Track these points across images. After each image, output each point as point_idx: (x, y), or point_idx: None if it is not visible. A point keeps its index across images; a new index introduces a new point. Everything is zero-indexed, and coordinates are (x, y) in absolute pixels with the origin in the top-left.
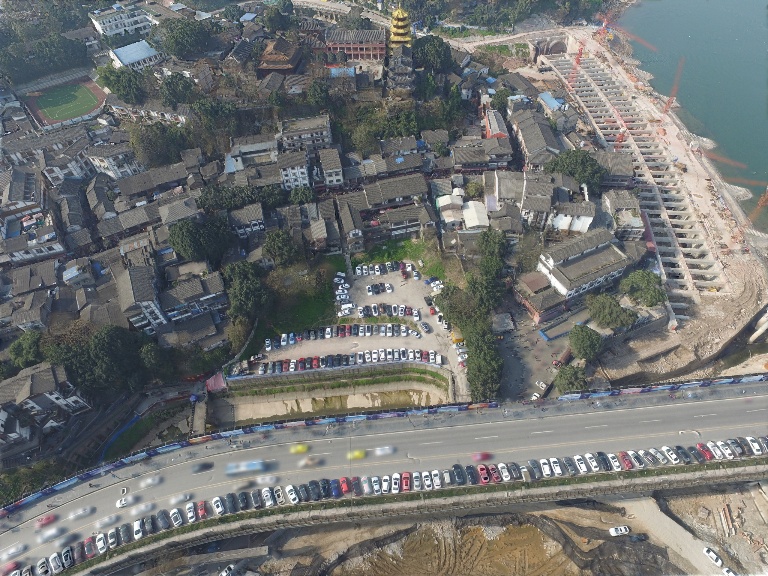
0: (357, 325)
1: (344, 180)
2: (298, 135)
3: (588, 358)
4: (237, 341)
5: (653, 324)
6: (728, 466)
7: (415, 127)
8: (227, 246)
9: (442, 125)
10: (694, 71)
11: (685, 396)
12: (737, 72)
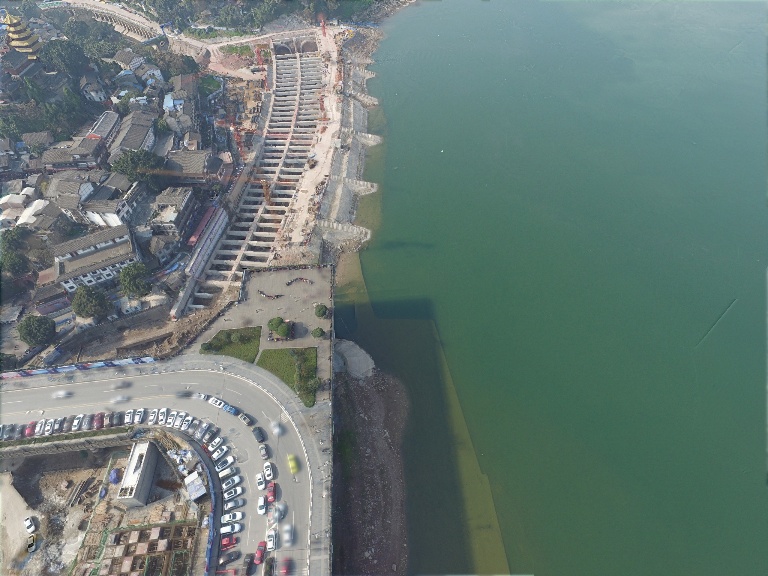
0: None
1: None
2: None
3: (63, 346)
4: None
5: (149, 313)
6: (39, 441)
7: (16, 129)
8: None
9: None
10: (417, 69)
11: (61, 379)
12: (456, 70)
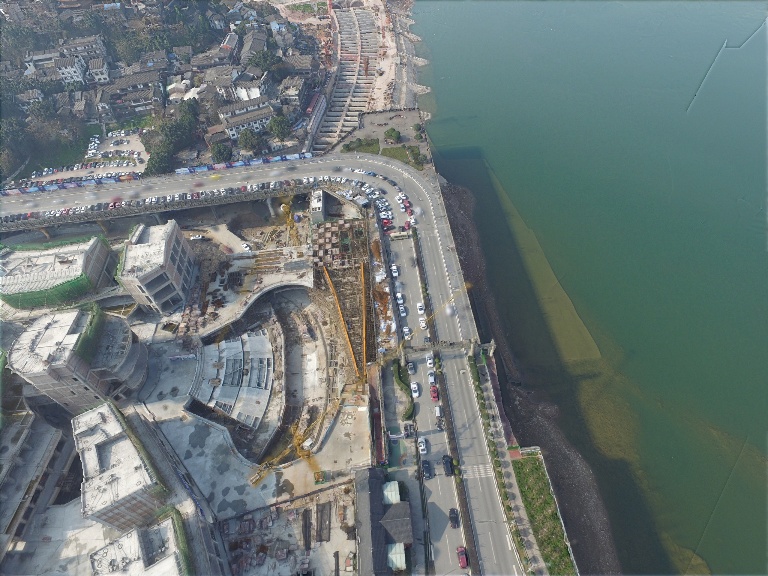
0: (97, 162)
1: (109, 78)
2: (74, 48)
3: None
4: (5, 166)
5: (288, 152)
6: None
7: (168, 44)
8: (10, 114)
9: (192, 44)
10: (449, 17)
11: (253, 168)
12: (480, 17)
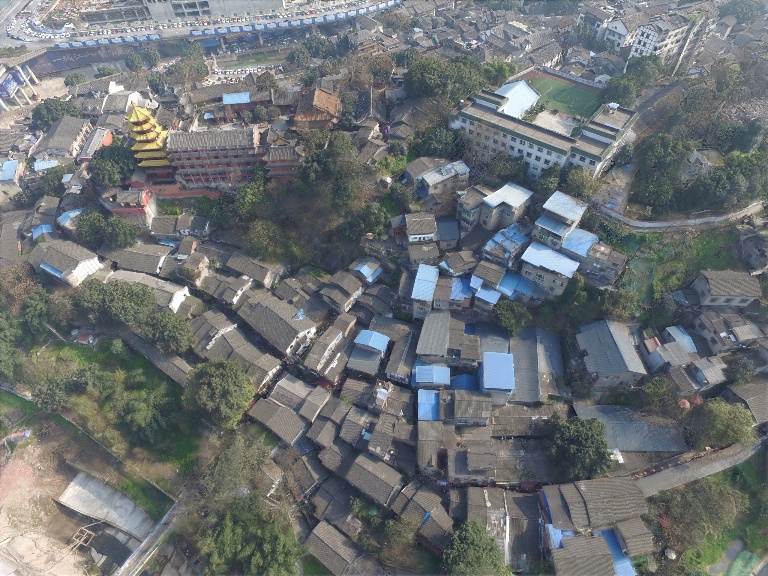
0: None
1: None
2: None
3: None
4: None
5: None
6: None
7: None
8: None
9: None
10: None
11: None
12: None
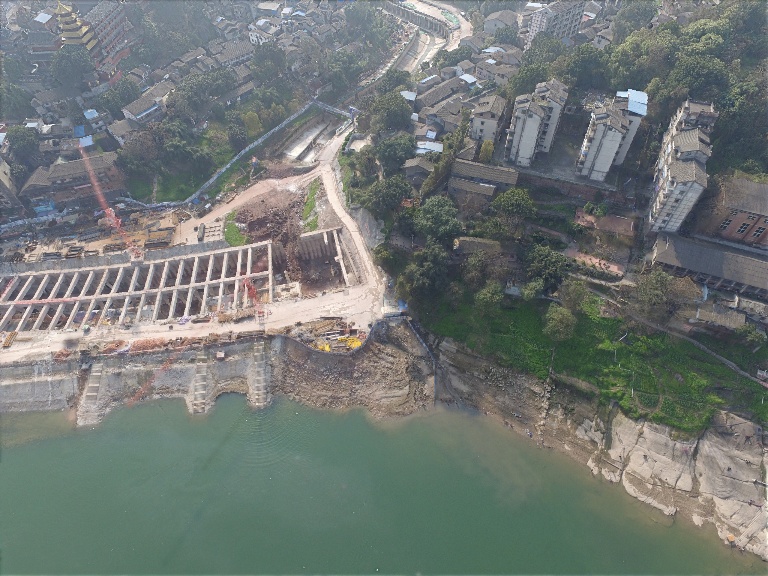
0: None
1: None
2: None
3: None
4: None
5: None
6: None
7: None
8: None
9: None
10: (193, 505)
11: None
12: None
